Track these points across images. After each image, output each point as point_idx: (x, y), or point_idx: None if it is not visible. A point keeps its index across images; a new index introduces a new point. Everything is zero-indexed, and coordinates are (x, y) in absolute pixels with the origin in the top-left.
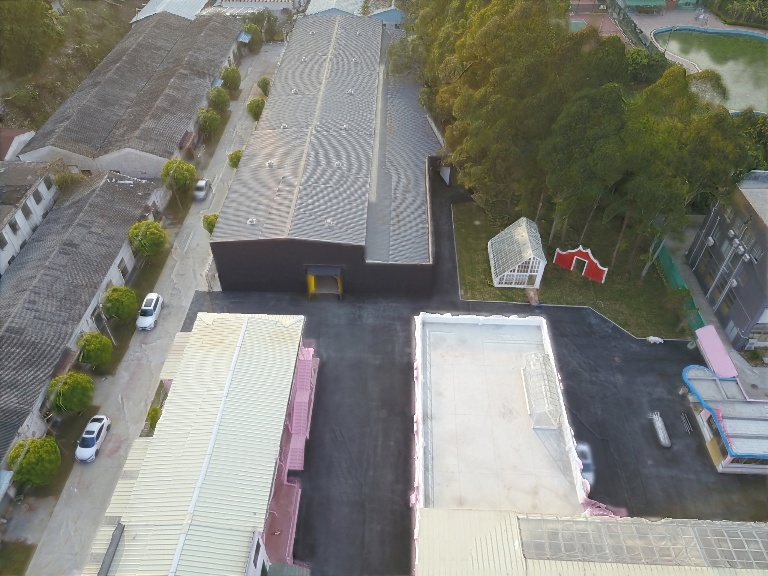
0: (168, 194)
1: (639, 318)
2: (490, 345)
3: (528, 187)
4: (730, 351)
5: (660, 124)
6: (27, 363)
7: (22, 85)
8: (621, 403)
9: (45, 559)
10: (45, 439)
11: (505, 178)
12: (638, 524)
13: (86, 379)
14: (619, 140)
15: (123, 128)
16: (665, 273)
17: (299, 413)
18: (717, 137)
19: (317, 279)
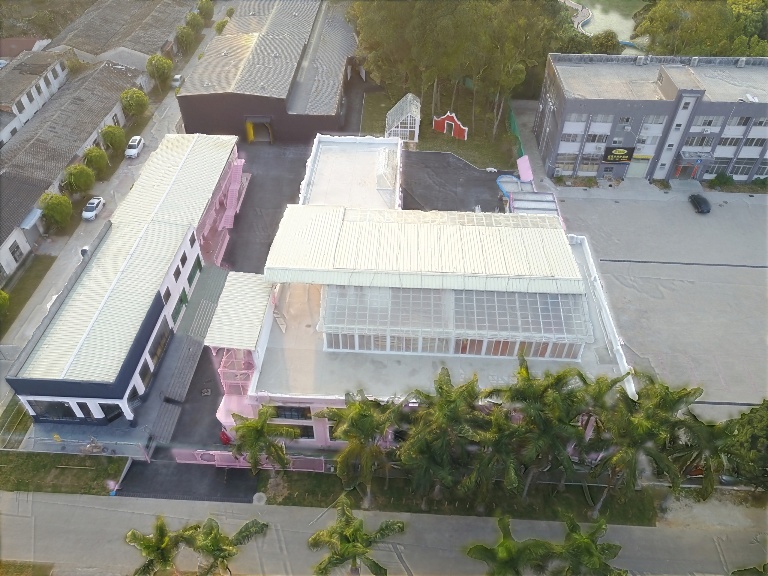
0: (152, 83)
1: (485, 159)
2: (361, 152)
3: (409, 67)
4: (544, 178)
5: (477, 4)
6: (50, 158)
7: (41, 10)
8: (456, 201)
9: (62, 262)
10: (62, 196)
11: (394, 62)
12: (416, 212)
13: (89, 170)
14: (453, 17)
15: (119, 37)
16: (512, 134)
17: (232, 196)
18: (513, 12)
19: (255, 129)
